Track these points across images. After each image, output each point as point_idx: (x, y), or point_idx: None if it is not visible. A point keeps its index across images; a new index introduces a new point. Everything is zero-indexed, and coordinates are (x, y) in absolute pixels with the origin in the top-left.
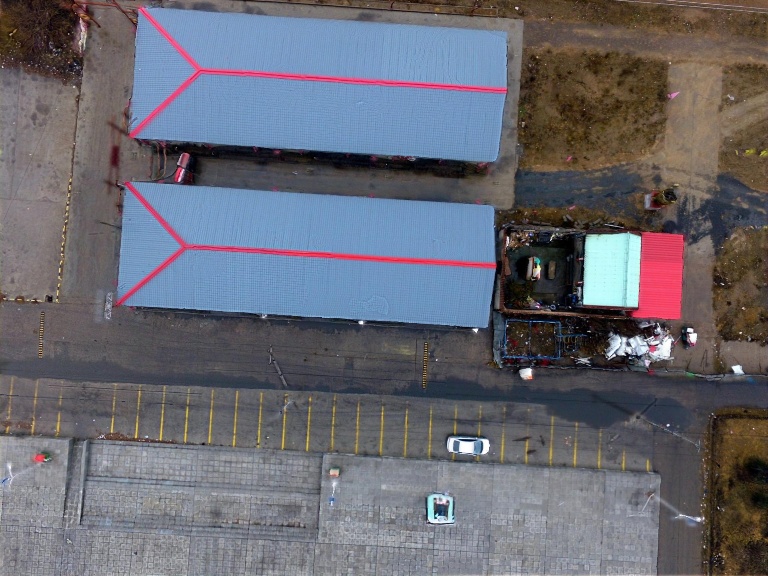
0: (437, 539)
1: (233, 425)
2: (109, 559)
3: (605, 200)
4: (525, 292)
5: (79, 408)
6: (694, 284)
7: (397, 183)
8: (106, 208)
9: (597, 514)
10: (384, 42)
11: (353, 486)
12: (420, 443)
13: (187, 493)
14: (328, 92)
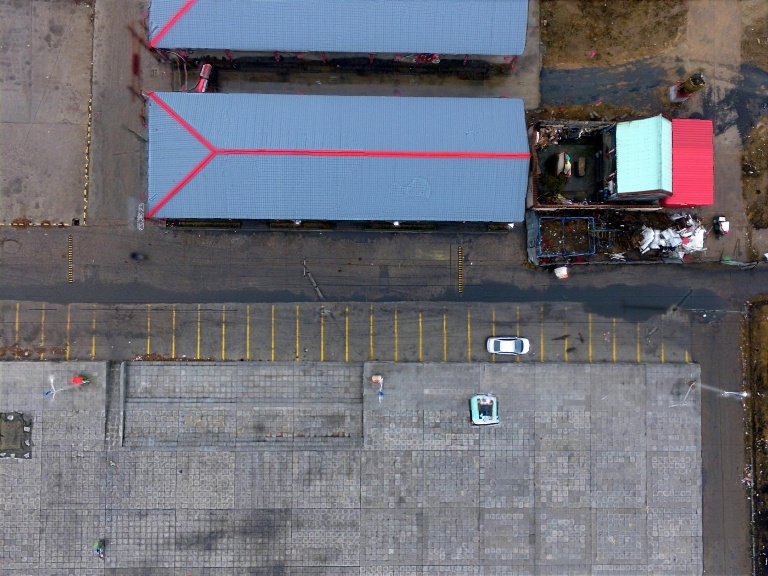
0: (482, 440)
1: (271, 339)
2: (154, 479)
3: (631, 95)
4: (559, 183)
5: (113, 331)
6: (723, 174)
7: (422, 88)
8: (128, 127)
9: (640, 406)
10: None
11: (396, 392)
12: (460, 347)
13: (229, 409)
14: None
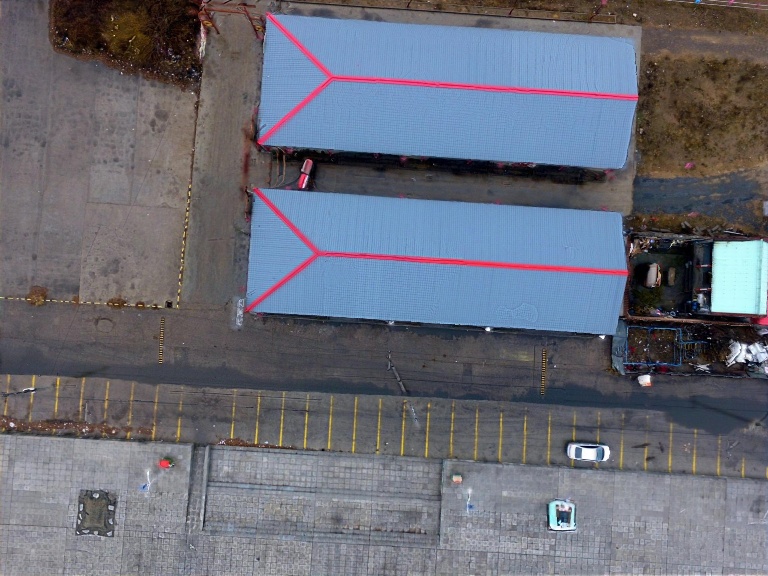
0: (558, 546)
1: (352, 431)
2: (232, 565)
3: (723, 207)
4: (653, 299)
5: (199, 414)
6: None
7: (515, 189)
8: (225, 214)
9: (718, 521)
10: (512, 49)
11: (474, 492)
12: (539, 449)
13: (308, 499)
14: (473, 100)
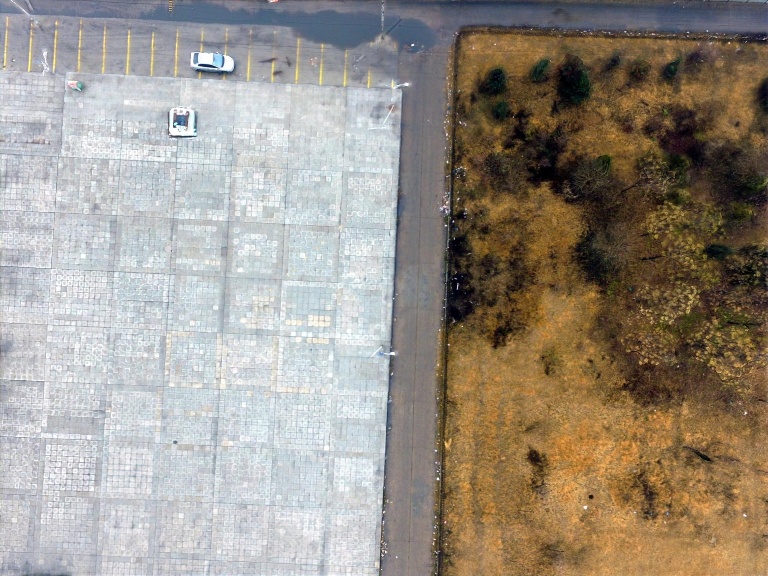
0: (180, 153)
1: None
2: None
3: None
4: None
5: None
6: None
7: None
8: None
9: (339, 127)
10: None
11: (96, 101)
12: (166, 65)
13: None
14: None
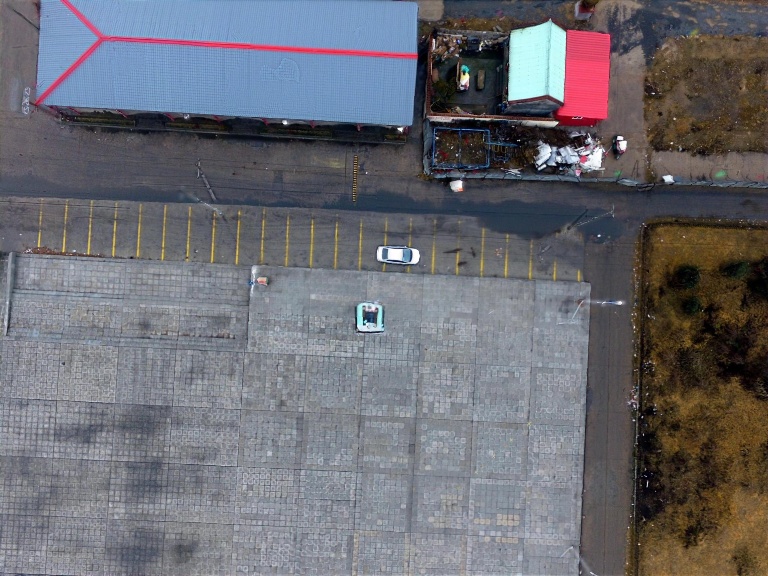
0: (367, 348)
1: (161, 239)
2: (37, 370)
3: (535, 11)
4: (449, 89)
5: (5, 222)
6: (625, 94)
7: None
8: None
9: (527, 322)
10: None
11: (282, 296)
12: (350, 256)
13: (115, 305)
14: None
